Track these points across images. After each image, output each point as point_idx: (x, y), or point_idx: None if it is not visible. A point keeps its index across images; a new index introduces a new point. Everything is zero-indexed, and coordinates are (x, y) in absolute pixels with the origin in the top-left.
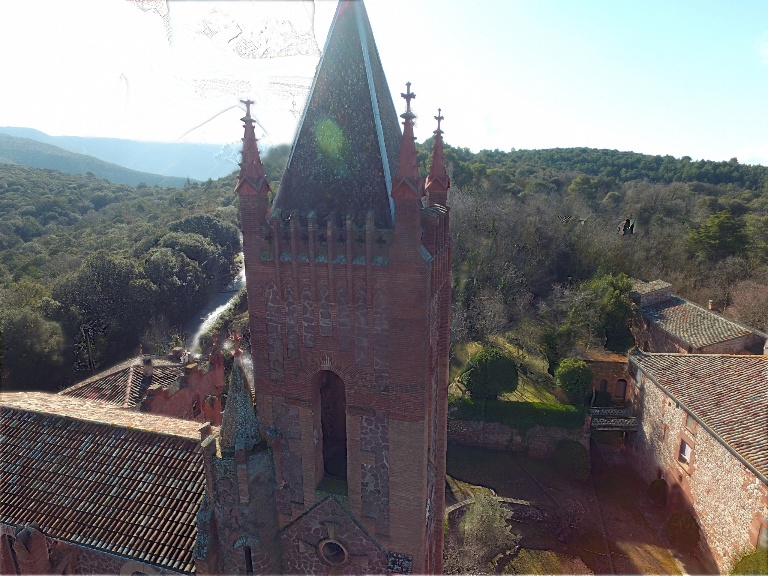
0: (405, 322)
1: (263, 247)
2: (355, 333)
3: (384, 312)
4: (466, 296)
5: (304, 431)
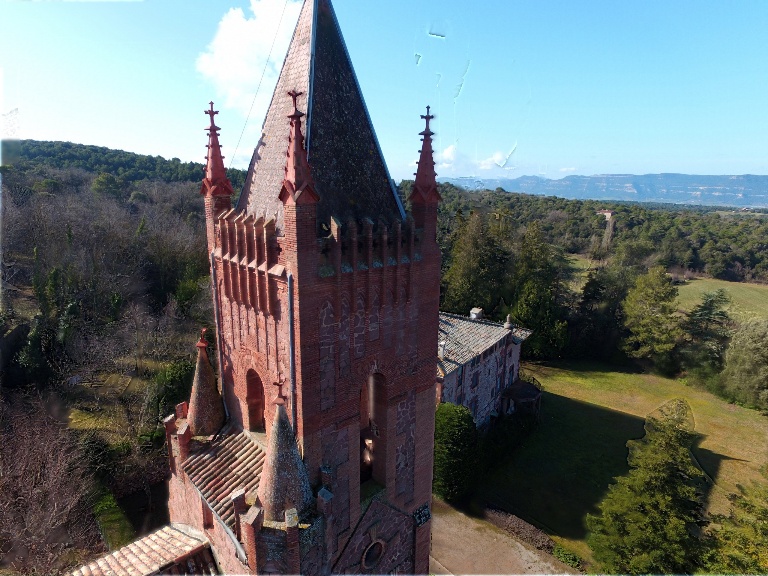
0: (429, 305)
1: (319, 262)
2: (395, 328)
3: (415, 301)
4: (152, 313)
5: (352, 449)
